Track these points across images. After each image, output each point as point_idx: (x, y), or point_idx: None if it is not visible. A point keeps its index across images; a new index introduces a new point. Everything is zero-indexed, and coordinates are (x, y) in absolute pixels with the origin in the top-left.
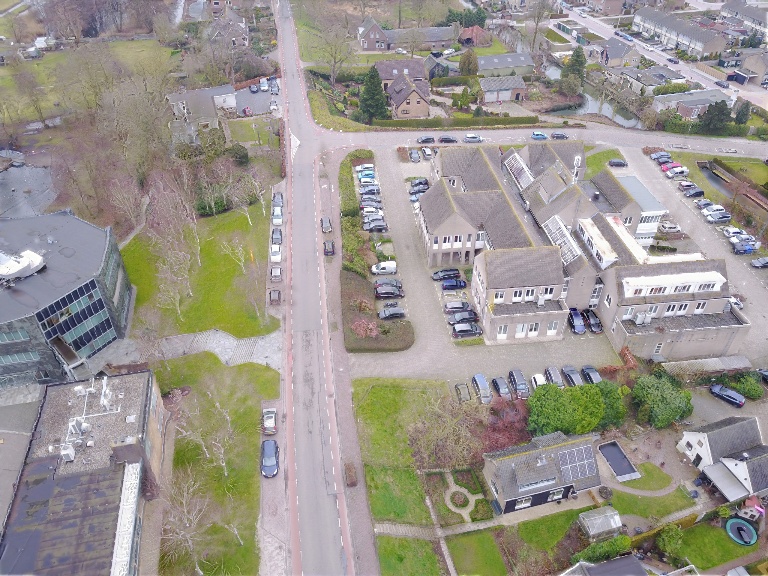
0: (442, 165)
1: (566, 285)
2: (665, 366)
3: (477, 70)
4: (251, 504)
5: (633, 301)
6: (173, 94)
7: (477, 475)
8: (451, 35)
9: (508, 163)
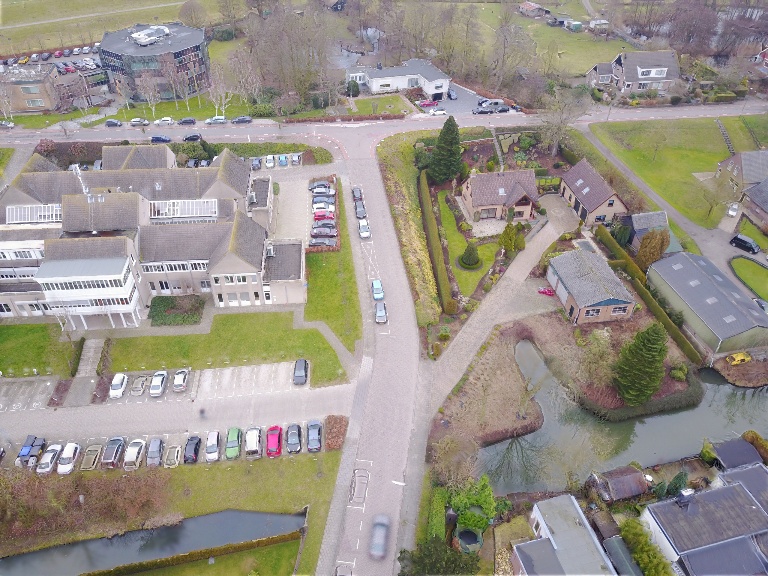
0: None
1: None
2: None
3: (646, 263)
4: None
5: None
6: (425, 61)
7: None
8: None
9: None
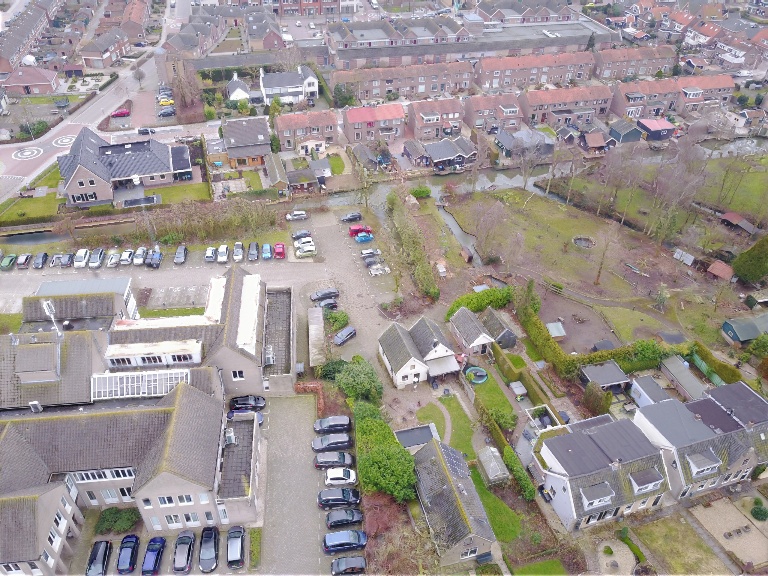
0: None
1: None
2: (315, 364)
3: None
4: None
5: (258, 352)
6: None
7: (445, 574)
8: None
9: None
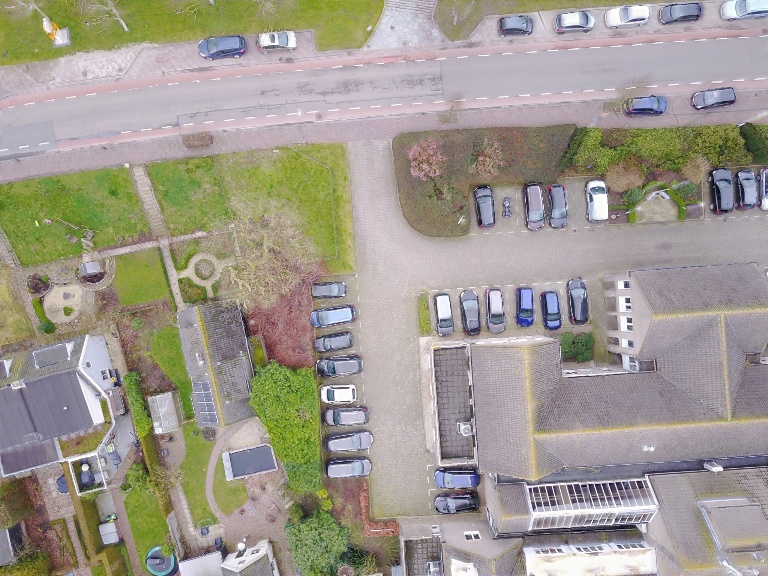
0: None
1: None
2: None
3: None
4: (169, 34)
5: (448, 568)
6: None
7: (237, 295)
8: None
9: None
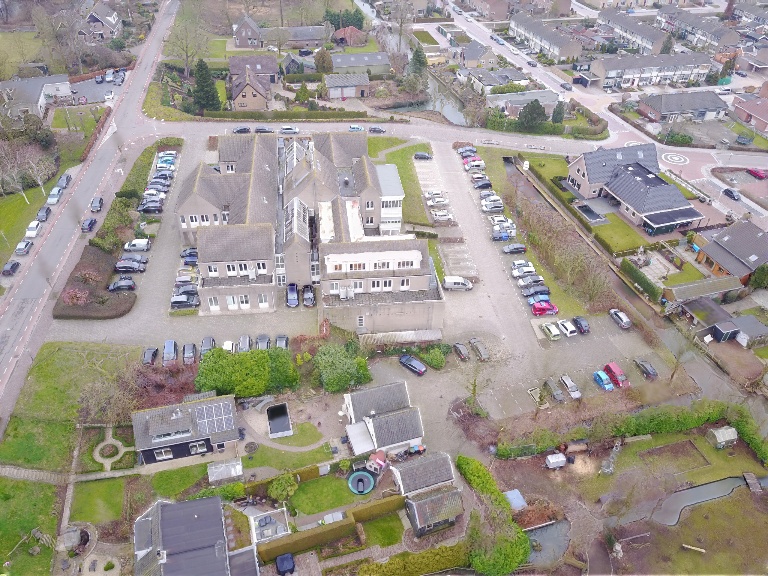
0: (219, 151)
1: (282, 261)
2: (360, 337)
3: (331, 67)
4: None
5: (335, 276)
6: (6, 81)
7: None
8: (323, 34)
9: (287, 151)
